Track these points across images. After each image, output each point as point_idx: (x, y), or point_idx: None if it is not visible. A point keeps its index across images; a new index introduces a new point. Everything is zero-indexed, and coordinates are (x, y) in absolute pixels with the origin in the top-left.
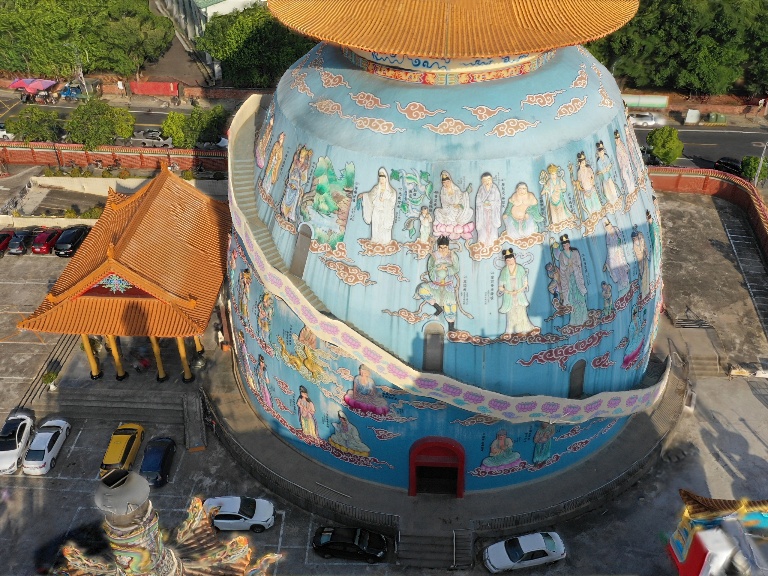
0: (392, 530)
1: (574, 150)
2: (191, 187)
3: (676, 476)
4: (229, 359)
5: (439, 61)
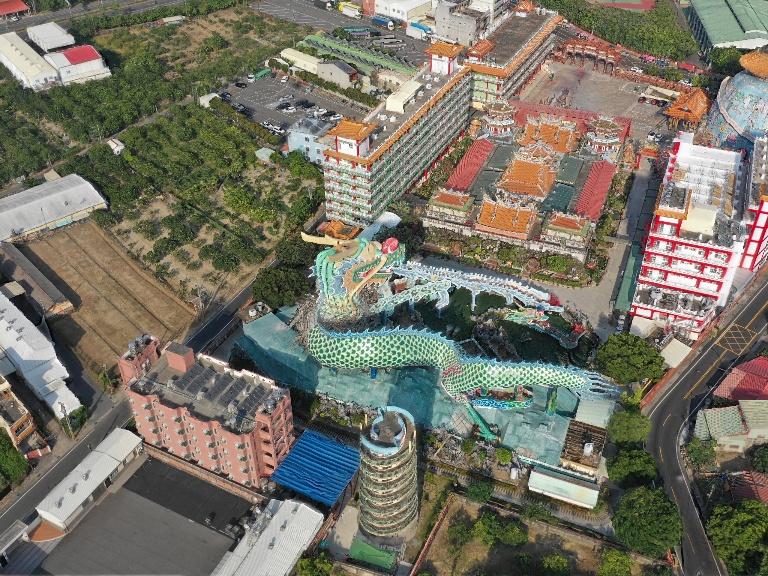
0: None
1: None
2: None
3: None
4: None
5: None
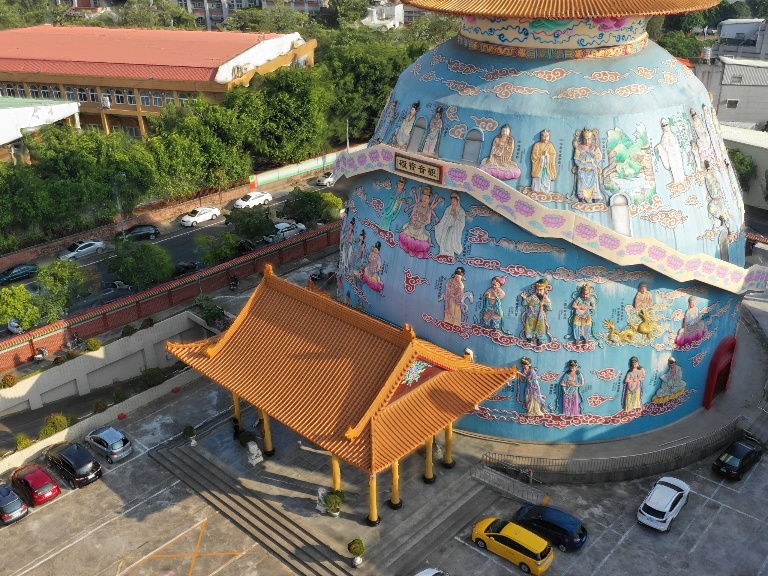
0: (738, 433)
1: None
2: None
3: None
4: (444, 432)
5: (631, 33)
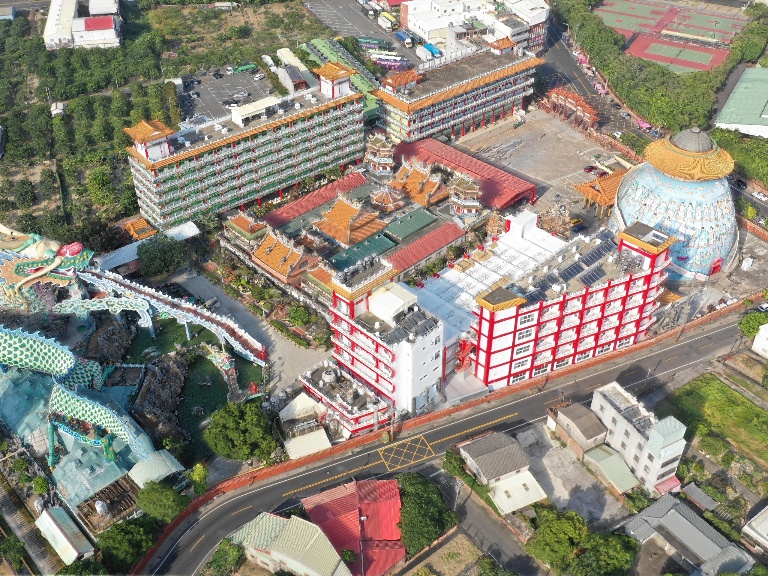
0: None
1: (682, 201)
2: None
3: (677, 293)
4: None
5: None
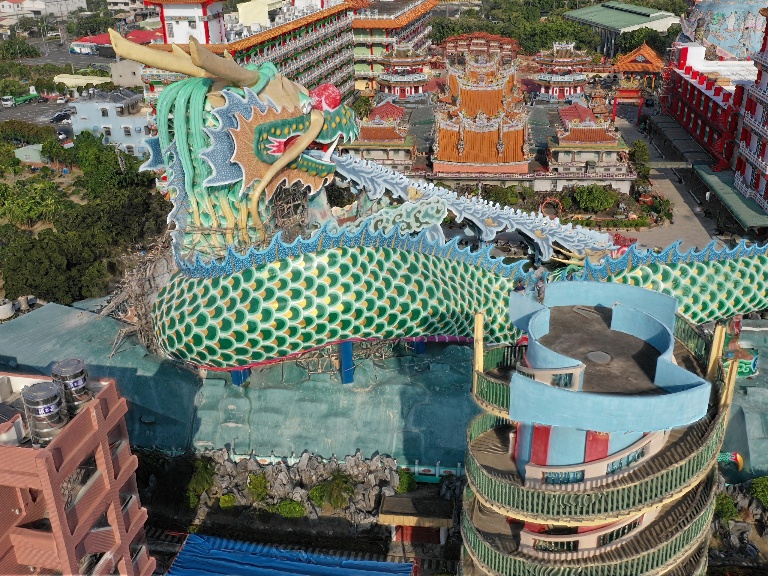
0: None
1: None
2: (651, 50)
3: None
4: None
5: None
